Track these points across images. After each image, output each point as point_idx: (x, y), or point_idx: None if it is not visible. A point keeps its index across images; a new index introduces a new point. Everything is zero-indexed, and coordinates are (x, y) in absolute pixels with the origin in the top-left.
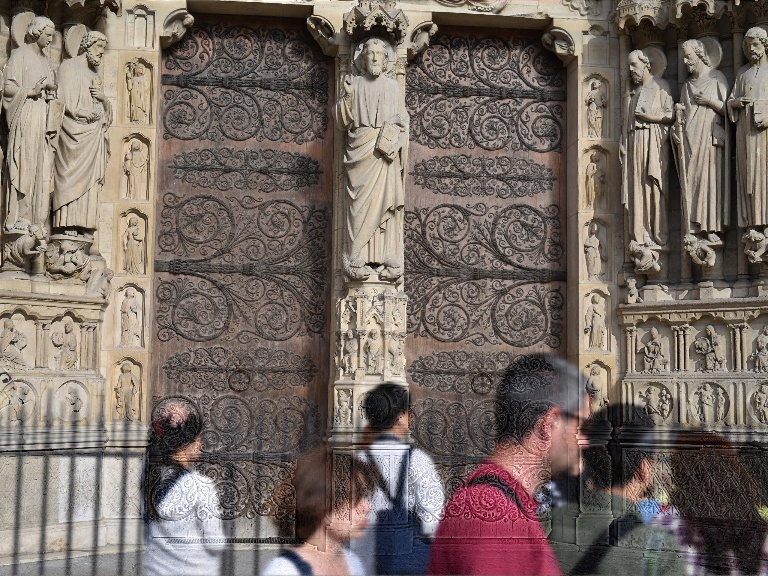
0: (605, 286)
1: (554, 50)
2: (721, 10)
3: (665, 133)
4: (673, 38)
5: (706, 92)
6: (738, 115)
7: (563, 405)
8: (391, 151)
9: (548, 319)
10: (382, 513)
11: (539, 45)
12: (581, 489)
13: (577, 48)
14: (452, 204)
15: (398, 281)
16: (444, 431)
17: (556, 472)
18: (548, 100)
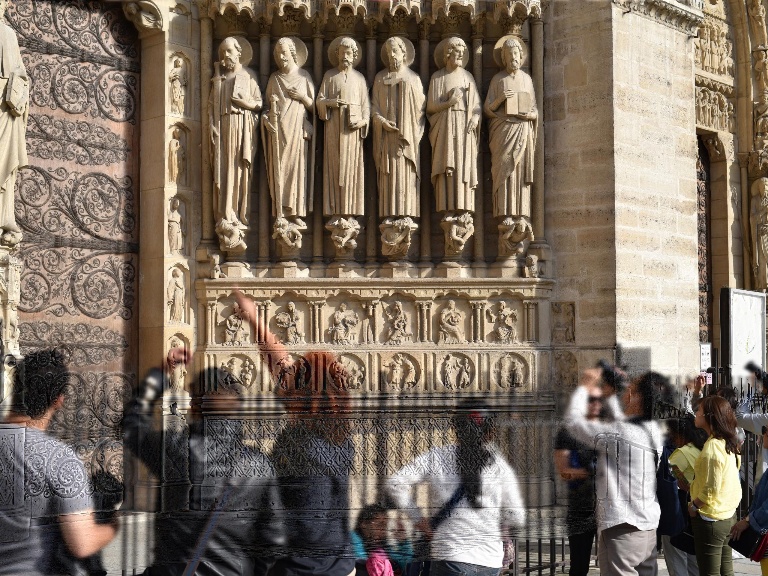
0: (186, 261)
1: (138, 21)
2: (313, 15)
3: (256, 120)
4: (254, 31)
5: (299, 88)
6: (330, 114)
7: (134, 376)
8: (20, 106)
9: (122, 291)
10: (6, 497)
11: (116, 12)
12: (164, 458)
13: (165, 24)
14: (35, 166)
15: (16, 247)
16: None
17: (127, 443)
18: (124, 69)
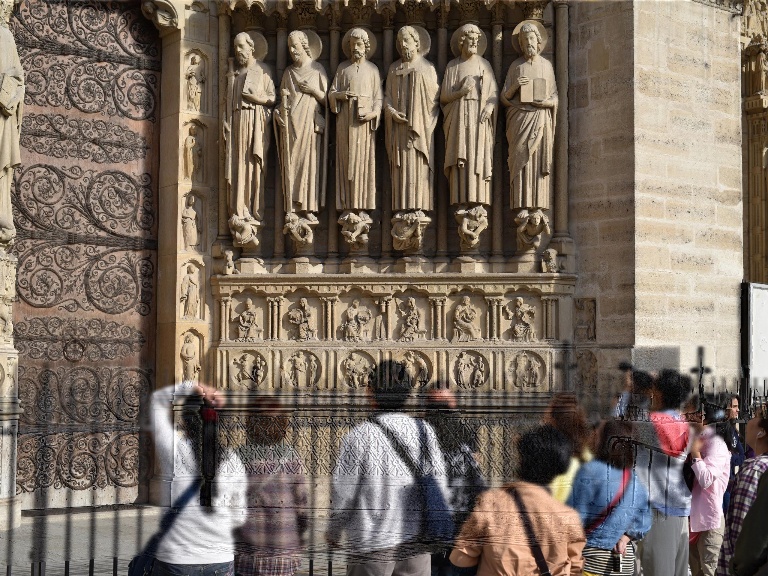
0: (200, 257)
1: (155, 19)
2: (326, 7)
3: (268, 115)
4: (272, 25)
5: (310, 82)
6: (341, 107)
7: (151, 372)
8: (11, 105)
9: (139, 287)
10: None
11: (136, 12)
12: (175, 453)
13: (180, 21)
14: (48, 165)
15: (10, 243)
16: (35, 399)
17: (143, 438)
18: (144, 68)
